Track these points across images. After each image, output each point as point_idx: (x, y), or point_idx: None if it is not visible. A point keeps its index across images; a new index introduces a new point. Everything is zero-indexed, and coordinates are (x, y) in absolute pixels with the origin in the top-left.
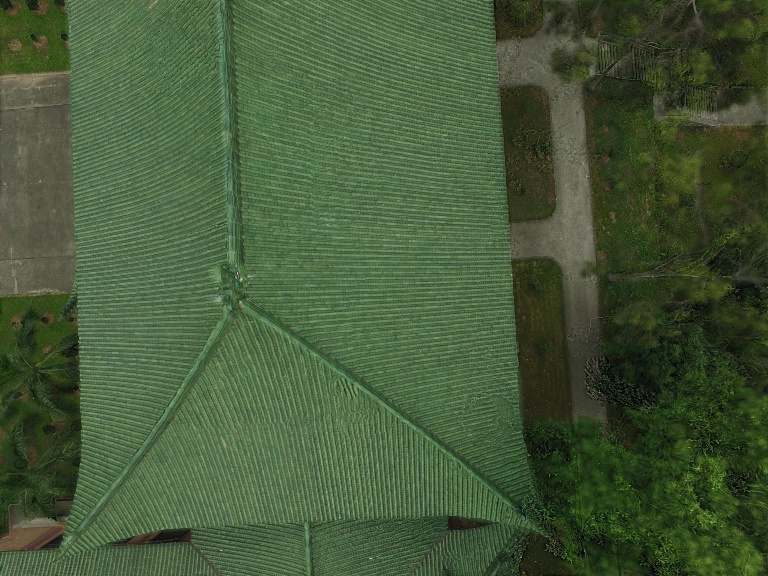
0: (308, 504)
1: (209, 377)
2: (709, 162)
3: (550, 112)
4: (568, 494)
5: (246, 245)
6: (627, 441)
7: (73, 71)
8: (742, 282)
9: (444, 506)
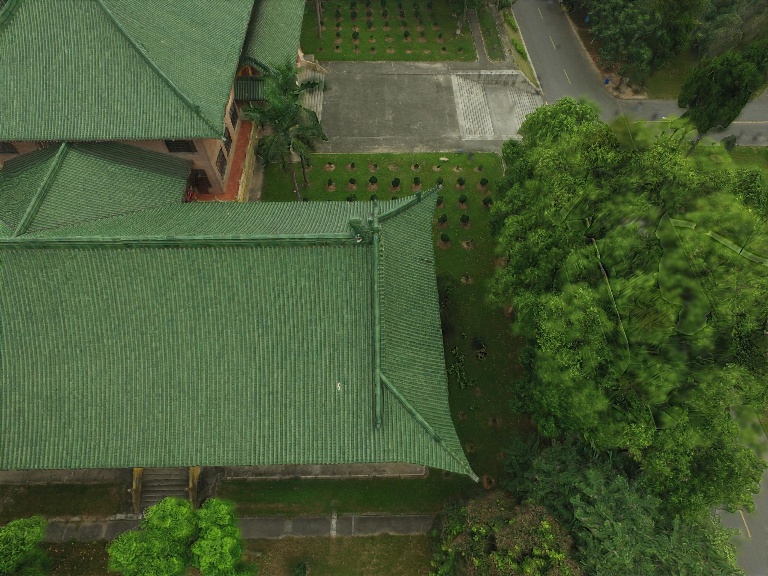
0: None
1: None
2: None
3: None
4: None
5: None
6: None
7: None
8: None
9: None
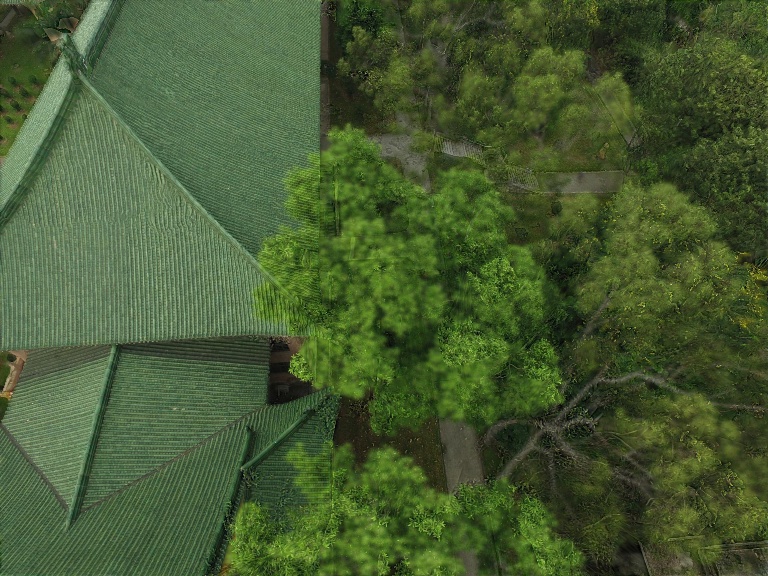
0: (117, 320)
1: (54, 166)
2: (538, 214)
3: (403, 171)
4: (347, 300)
5: (98, 64)
6: (487, 406)
7: (46, 84)
8: (556, 259)
9: (242, 324)
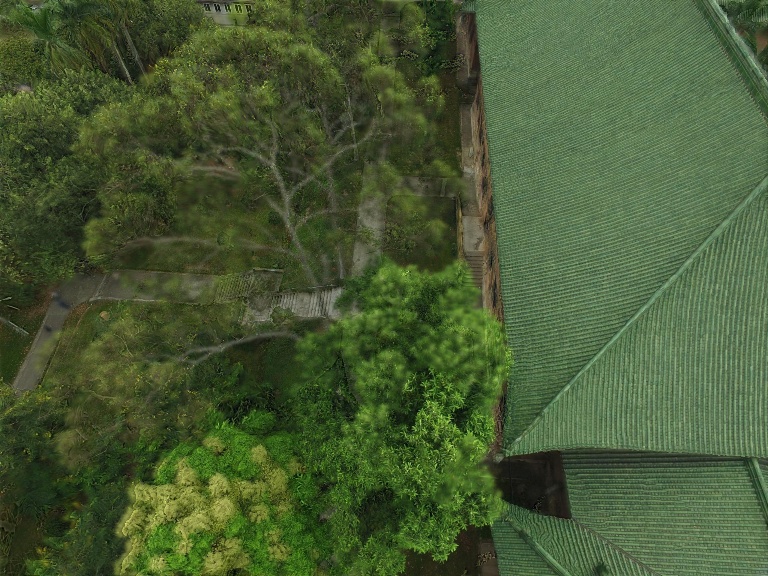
0: None
1: None
2: (241, 250)
3: (382, 262)
4: None
5: None
6: None
7: None
8: (277, 133)
9: None
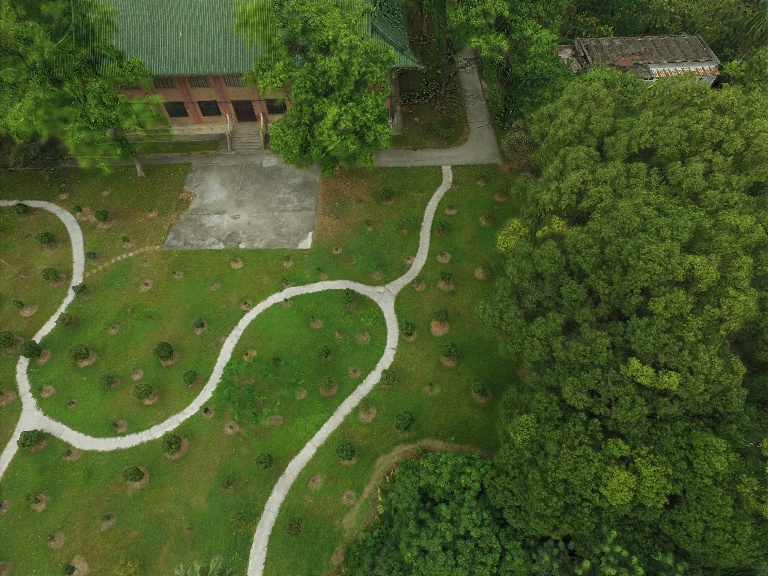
0: None
1: None
2: None
3: None
4: None
5: None
6: None
7: None
8: None
9: None
